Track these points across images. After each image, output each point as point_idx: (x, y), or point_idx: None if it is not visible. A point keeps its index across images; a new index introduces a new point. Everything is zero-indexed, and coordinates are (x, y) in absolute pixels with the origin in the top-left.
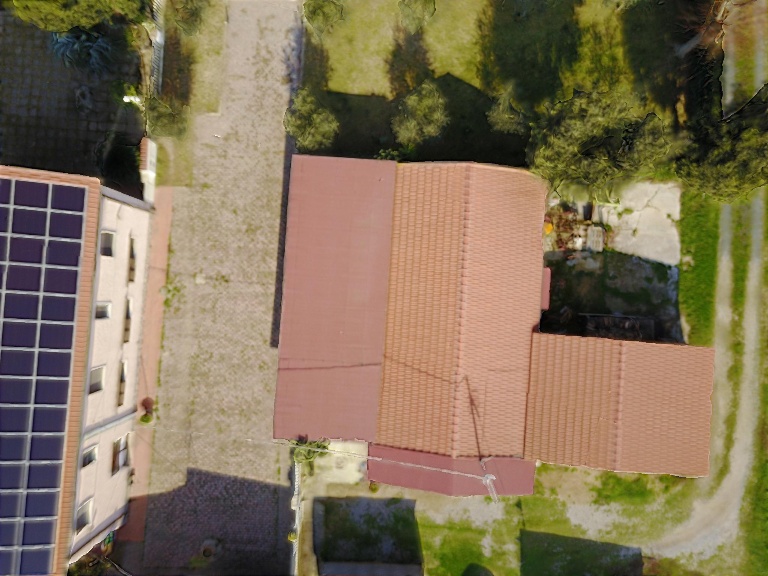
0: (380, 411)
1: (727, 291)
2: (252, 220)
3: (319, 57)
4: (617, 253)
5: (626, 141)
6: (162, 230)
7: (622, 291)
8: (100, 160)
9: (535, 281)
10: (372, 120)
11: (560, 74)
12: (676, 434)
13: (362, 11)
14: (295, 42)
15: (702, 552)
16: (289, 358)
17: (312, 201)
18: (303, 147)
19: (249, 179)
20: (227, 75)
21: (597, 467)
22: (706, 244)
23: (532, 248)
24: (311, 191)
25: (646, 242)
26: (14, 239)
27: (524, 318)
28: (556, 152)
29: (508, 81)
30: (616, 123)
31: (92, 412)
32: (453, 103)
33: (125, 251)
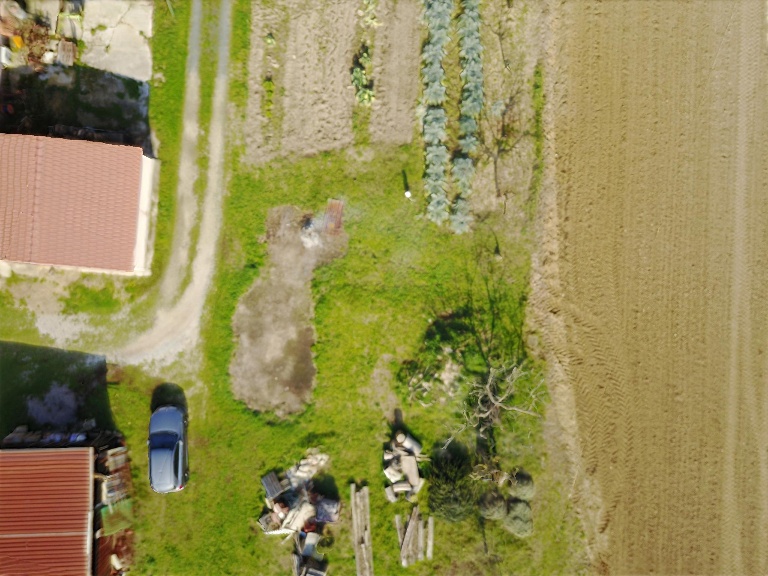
0: None
1: (195, 106)
2: None
3: None
4: (89, 68)
5: None
6: None
7: (94, 105)
8: None
9: None
10: None
11: None
12: (98, 229)
13: None
14: None
15: (163, 358)
16: None
17: None
18: None
19: None
20: None
21: (16, 260)
22: (175, 60)
23: None
24: None
25: (119, 58)
26: None
27: None
28: None
29: None
30: None
31: None
32: None
33: None
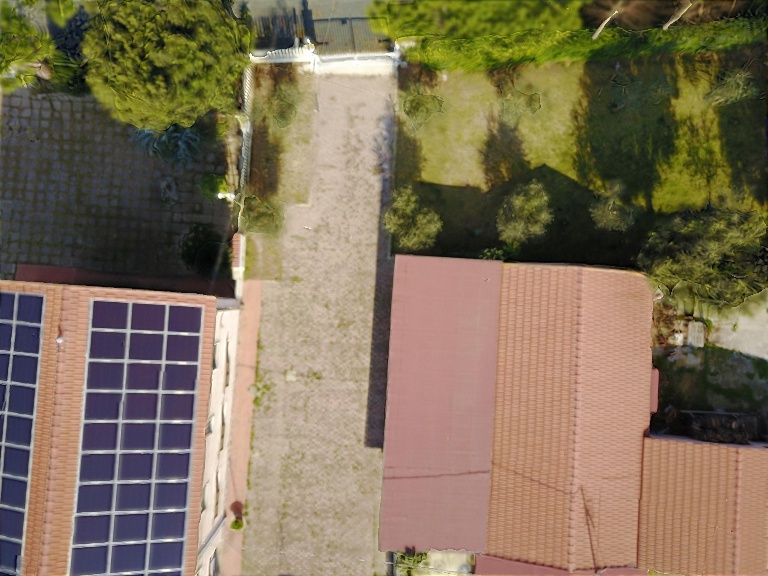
0: (488, 520)
1: None
2: (344, 315)
3: (412, 147)
4: (718, 348)
5: (764, 261)
6: (251, 326)
7: (724, 387)
8: (187, 254)
9: (645, 384)
10: (467, 212)
11: (658, 166)
12: None
13: (456, 100)
14: (387, 131)
15: None
16: (394, 466)
17: (417, 303)
18: (407, 247)
19: (341, 272)
20: (317, 165)
21: None
22: None
23: (642, 350)
24: (415, 292)
25: (746, 337)
26: (131, 366)
27: (635, 422)
28: (688, 268)
29: (605, 173)
30: (751, 240)
31: (199, 536)
32: (550, 195)
33: (223, 357)
